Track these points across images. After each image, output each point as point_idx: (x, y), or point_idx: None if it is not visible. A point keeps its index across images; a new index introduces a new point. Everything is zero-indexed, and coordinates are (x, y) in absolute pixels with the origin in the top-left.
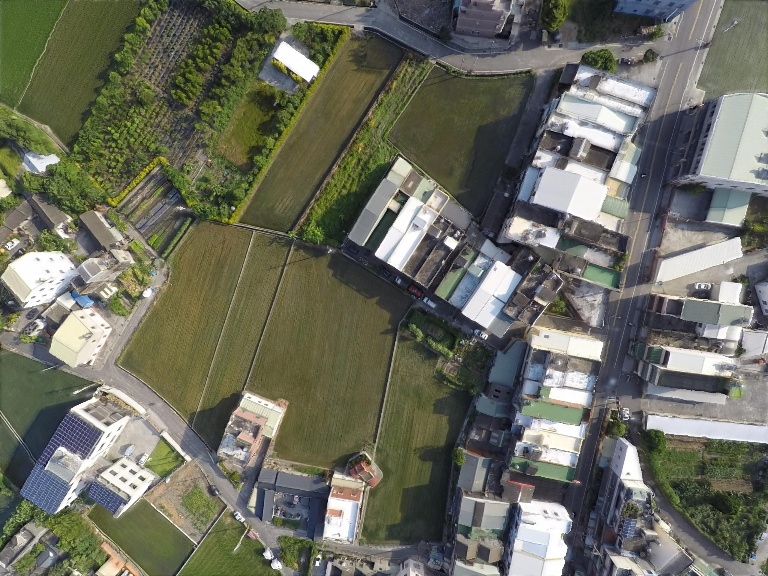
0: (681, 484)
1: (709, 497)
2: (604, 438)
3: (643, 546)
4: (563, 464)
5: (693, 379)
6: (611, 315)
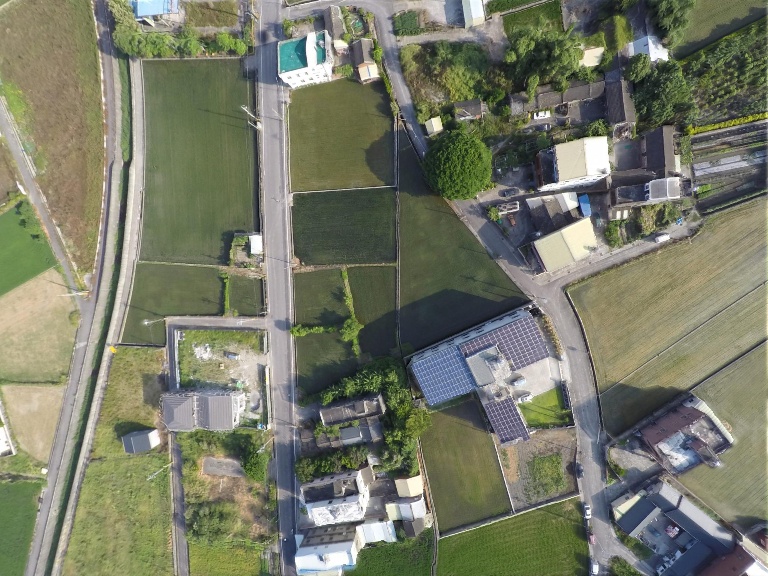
0: None
1: None
2: None
3: None
4: None
5: None
6: None
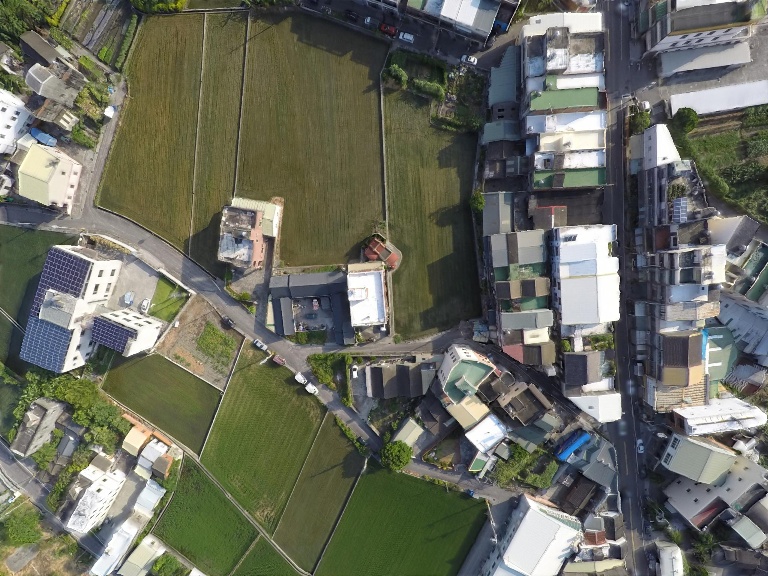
0: (725, 170)
1: (760, 176)
2: (629, 140)
3: (701, 233)
4: (591, 167)
5: (708, 12)
6: (603, 0)
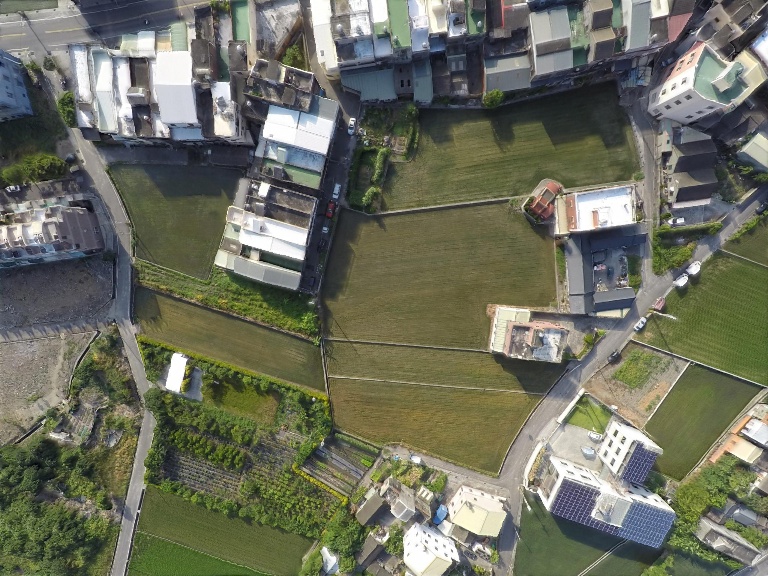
0: None
1: None
2: None
3: None
4: None
5: None
6: None
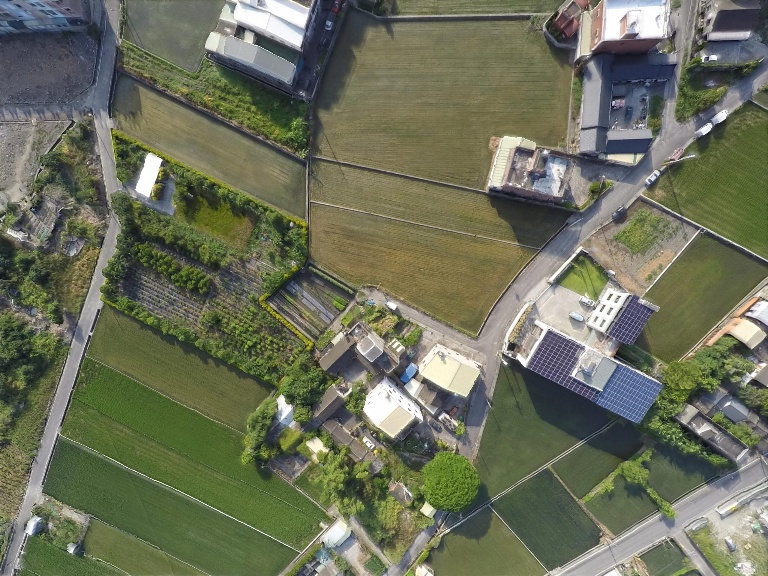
0: None
1: None
2: None
3: None
4: None
5: None
6: None
